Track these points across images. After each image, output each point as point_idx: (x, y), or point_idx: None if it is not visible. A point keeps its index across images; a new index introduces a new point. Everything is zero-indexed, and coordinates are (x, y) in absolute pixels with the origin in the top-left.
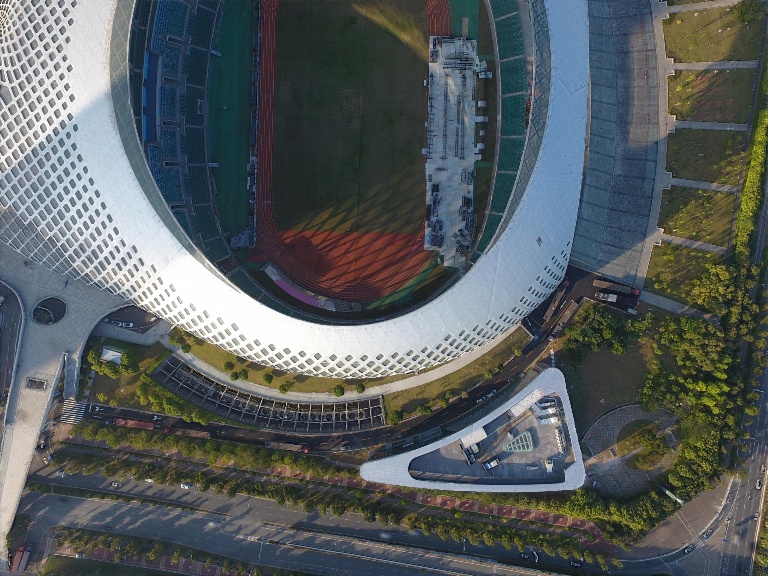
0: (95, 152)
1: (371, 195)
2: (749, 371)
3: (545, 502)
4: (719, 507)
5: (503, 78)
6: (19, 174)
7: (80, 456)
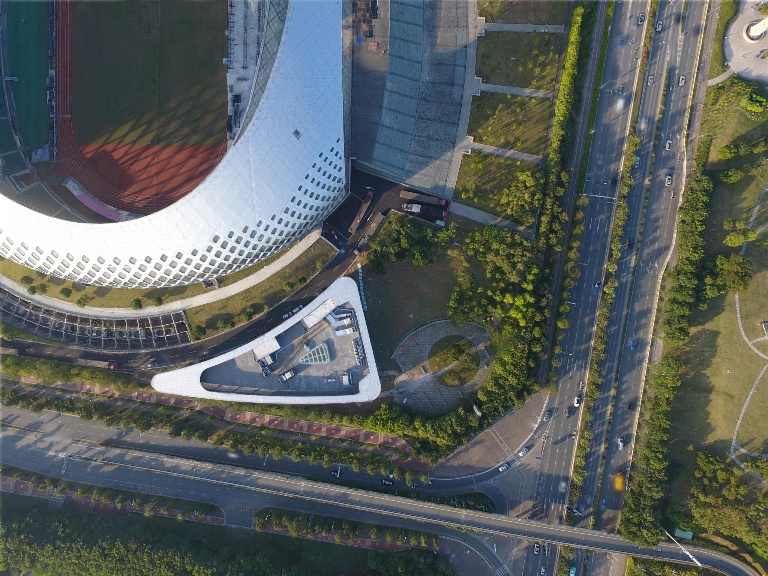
0: None
1: (172, 107)
2: (562, 283)
3: (348, 417)
4: (535, 425)
5: None
6: None
7: None
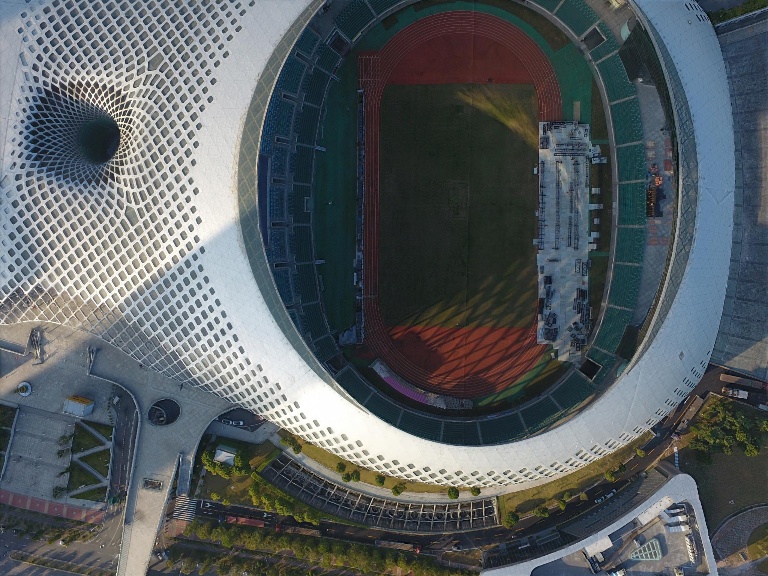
0: (222, 275)
1: (480, 288)
2: None
3: None
4: None
5: (620, 164)
6: (145, 293)
7: (192, 552)
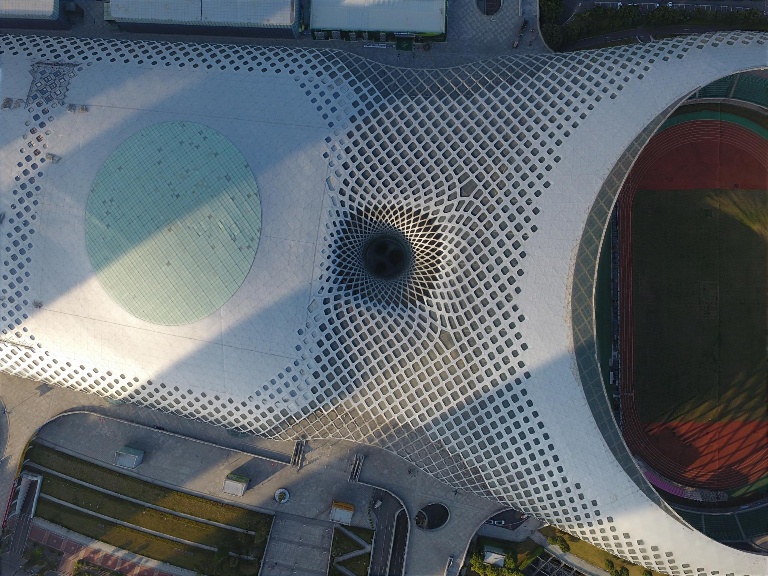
0: (550, 399)
1: (731, 384)
2: None
3: None
4: None
5: None
6: (456, 413)
7: None
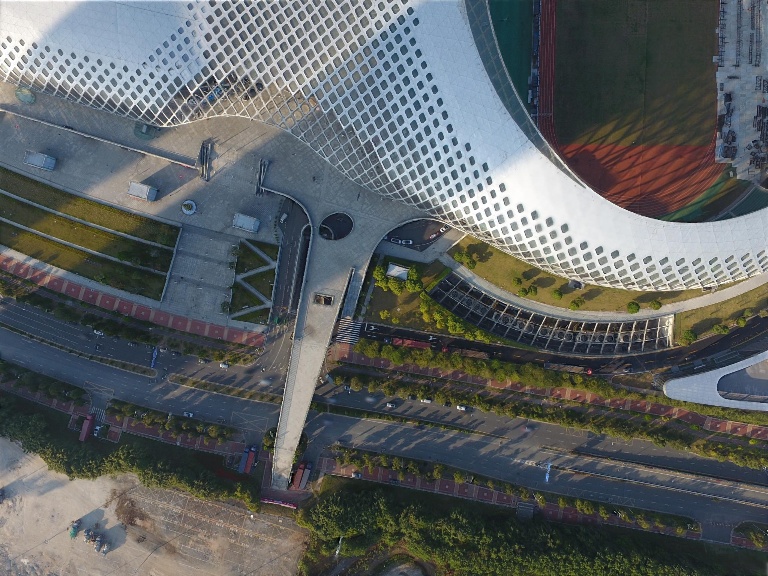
0: (438, 45)
1: (658, 106)
2: None
3: None
4: None
5: None
6: (347, 75)
7: (355, 376)
